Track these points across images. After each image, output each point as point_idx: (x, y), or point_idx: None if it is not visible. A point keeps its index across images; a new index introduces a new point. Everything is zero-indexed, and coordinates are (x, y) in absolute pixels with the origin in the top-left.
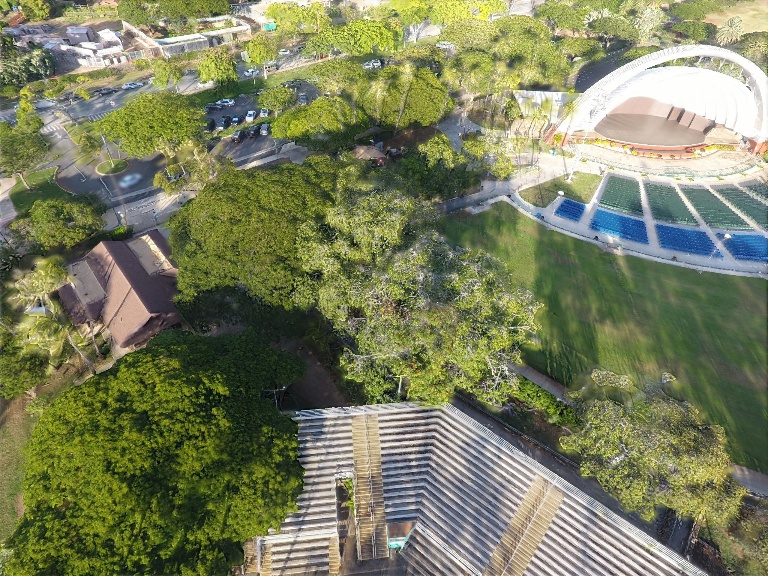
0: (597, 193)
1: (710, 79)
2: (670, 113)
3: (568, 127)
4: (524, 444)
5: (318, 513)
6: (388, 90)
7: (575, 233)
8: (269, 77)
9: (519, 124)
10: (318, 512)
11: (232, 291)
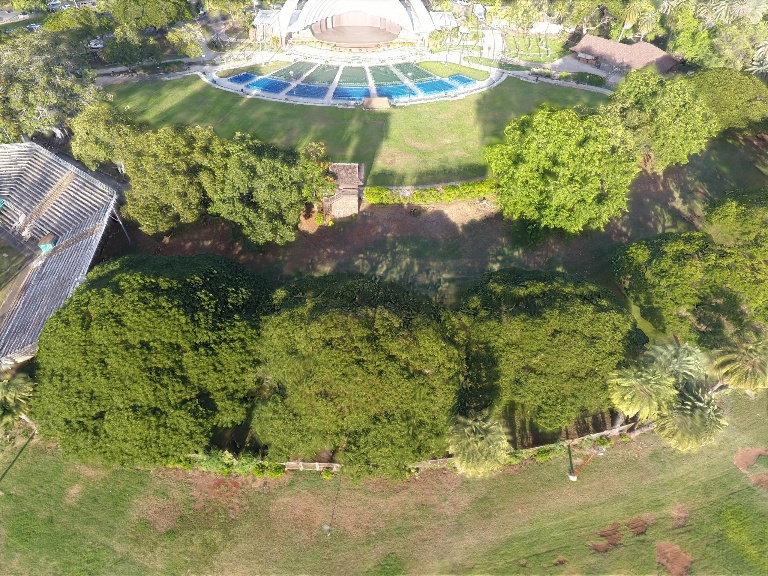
0: None
1: None
2: (380, 23)
3: (280, 30)
4: (90, 170)
5: None
6: (129, 3)
7: (230, 89)
8: None
9: (254, 33)
10: None
11: None
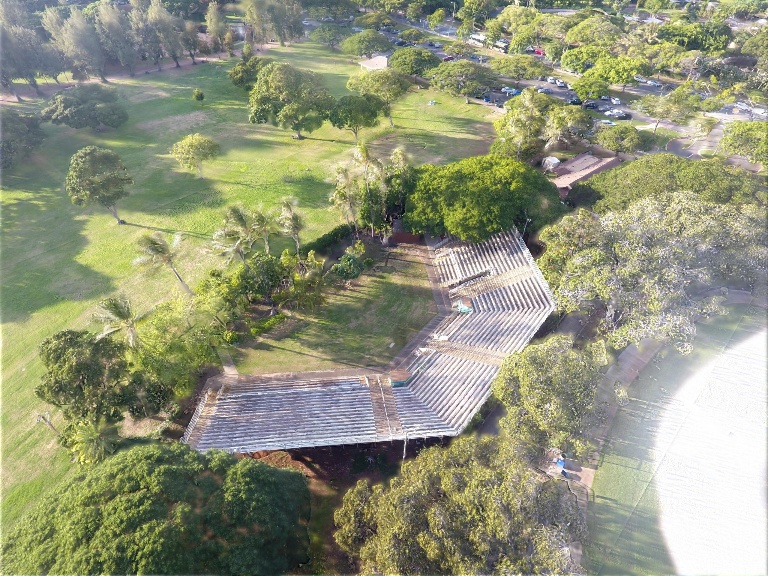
0: None
1: None
2: None
3: None
4: None
5: (468, 269)
6: None
7: None
8: None
9: None
10: (469, 269)
11: (598, 197)
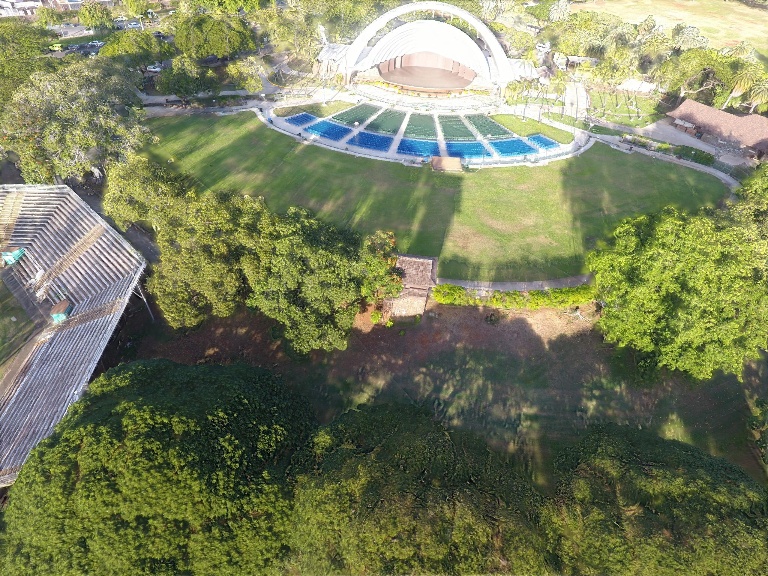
0: (338, 113)
1: (443, 30)
2: (452, 66)
3: (345, 68)
4: None
5: None
6: (192, 29)
7: (286, 131)
8: (147, 29)
9: (318, 67)
10: None
11: None
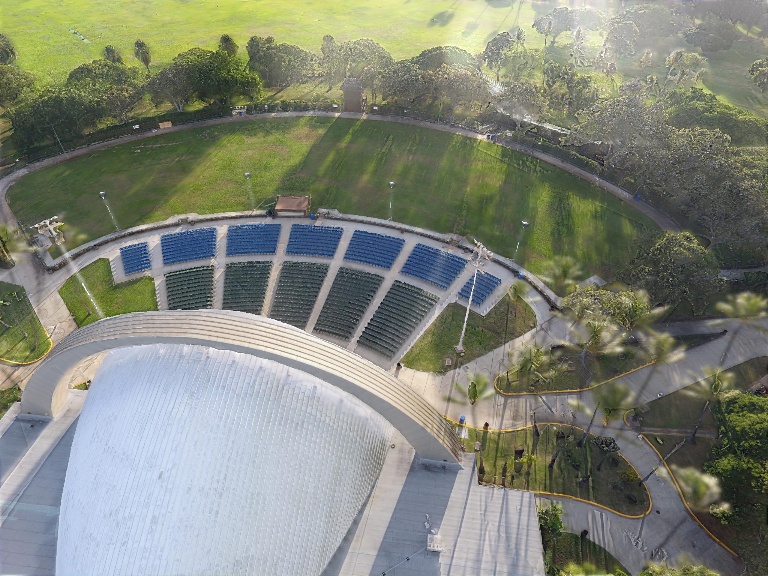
0: (429, 322)
1: None
2: None
3: None
4: None
5: None
6: None
7: None
8: None
9: None
10: None
11: None
